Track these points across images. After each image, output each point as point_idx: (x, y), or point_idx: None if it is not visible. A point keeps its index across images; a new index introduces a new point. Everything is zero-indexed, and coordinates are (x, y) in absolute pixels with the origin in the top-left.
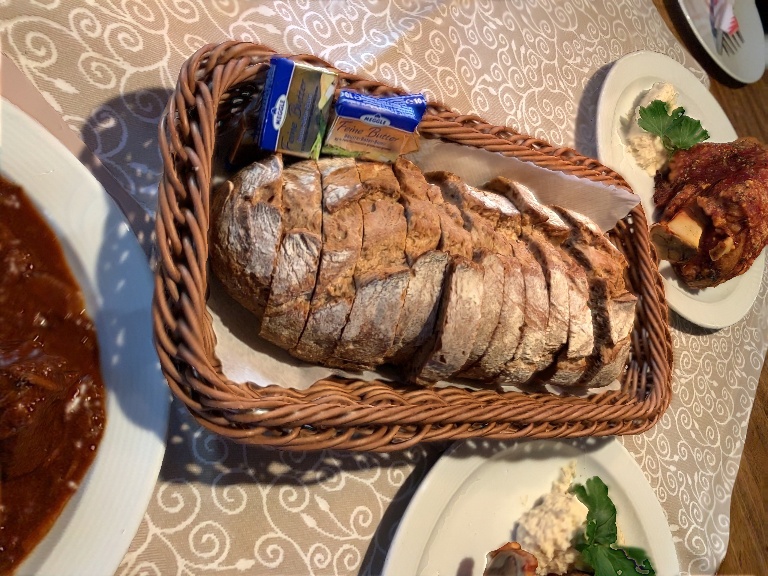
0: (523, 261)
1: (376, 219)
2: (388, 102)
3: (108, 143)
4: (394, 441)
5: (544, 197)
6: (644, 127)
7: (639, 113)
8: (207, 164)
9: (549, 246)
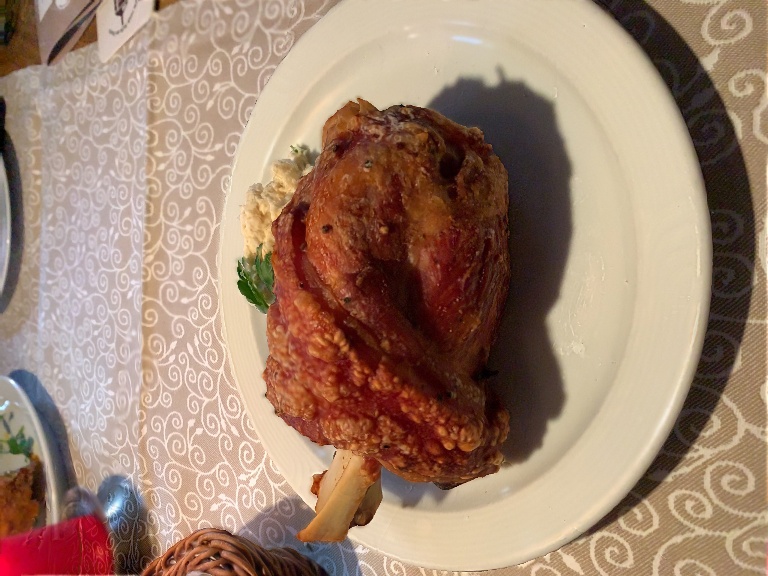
0: None
1: None
2: None
3: None
4: None
5: None
6: (263, 311)
7: (249, 302)
8: None
9: None
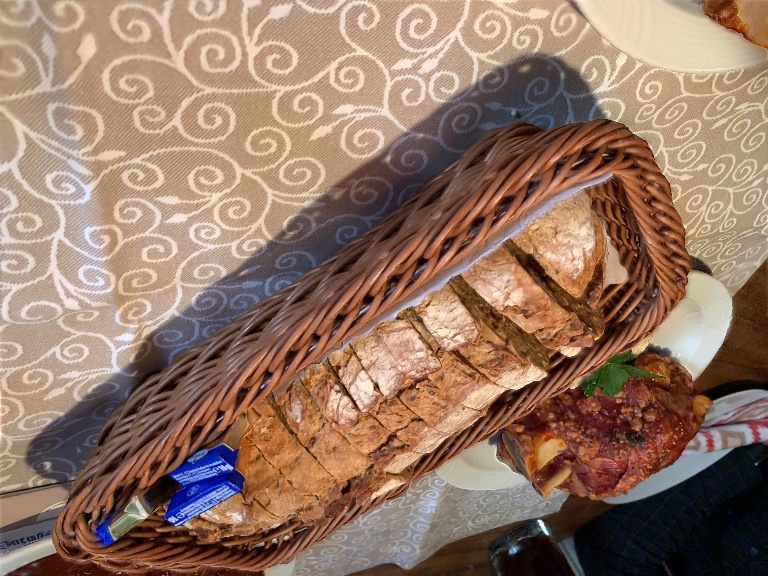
0: (428, 417)
1: (277, 506)
2: (203, 497)
3: (64, 469)
4: (390, 496)
5: None
6: None
7: None
8: (151, 556)
9: (455, 375)
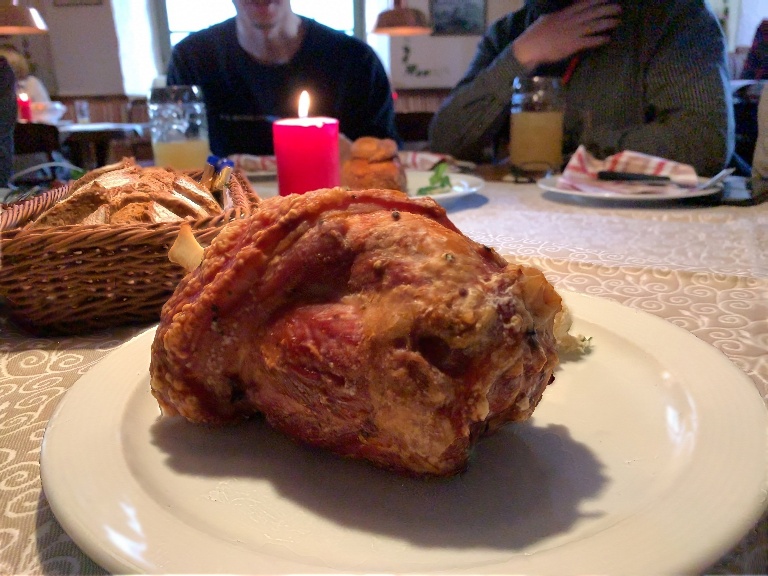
0: None
1: None
2: None
3: None
4: None
5: None
6: None
7: None
8: None
9: None
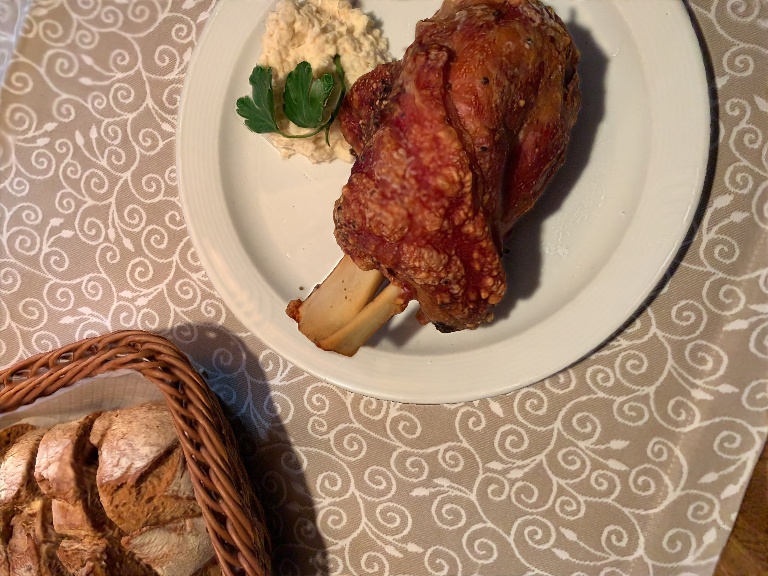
0: None
1: None
2: None
3: None
4: None
5: (59, 411)
6: (256, 130)
7: (238, 114)
8: None
9: None
